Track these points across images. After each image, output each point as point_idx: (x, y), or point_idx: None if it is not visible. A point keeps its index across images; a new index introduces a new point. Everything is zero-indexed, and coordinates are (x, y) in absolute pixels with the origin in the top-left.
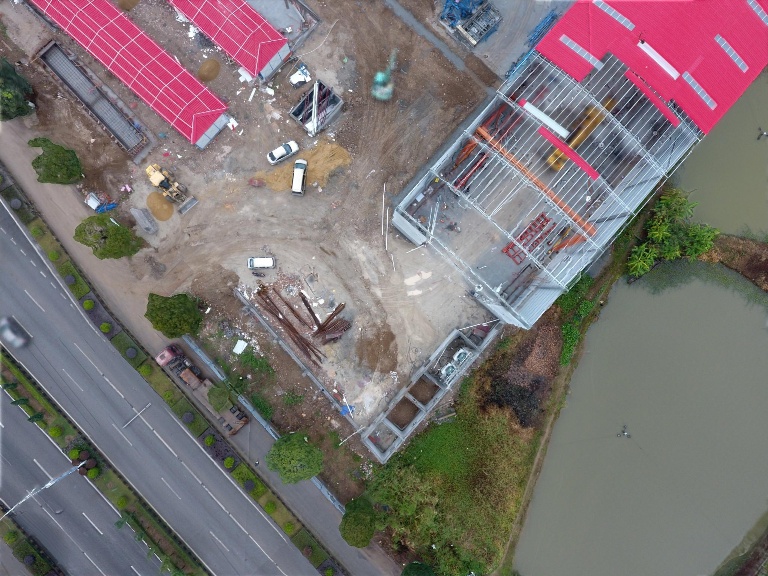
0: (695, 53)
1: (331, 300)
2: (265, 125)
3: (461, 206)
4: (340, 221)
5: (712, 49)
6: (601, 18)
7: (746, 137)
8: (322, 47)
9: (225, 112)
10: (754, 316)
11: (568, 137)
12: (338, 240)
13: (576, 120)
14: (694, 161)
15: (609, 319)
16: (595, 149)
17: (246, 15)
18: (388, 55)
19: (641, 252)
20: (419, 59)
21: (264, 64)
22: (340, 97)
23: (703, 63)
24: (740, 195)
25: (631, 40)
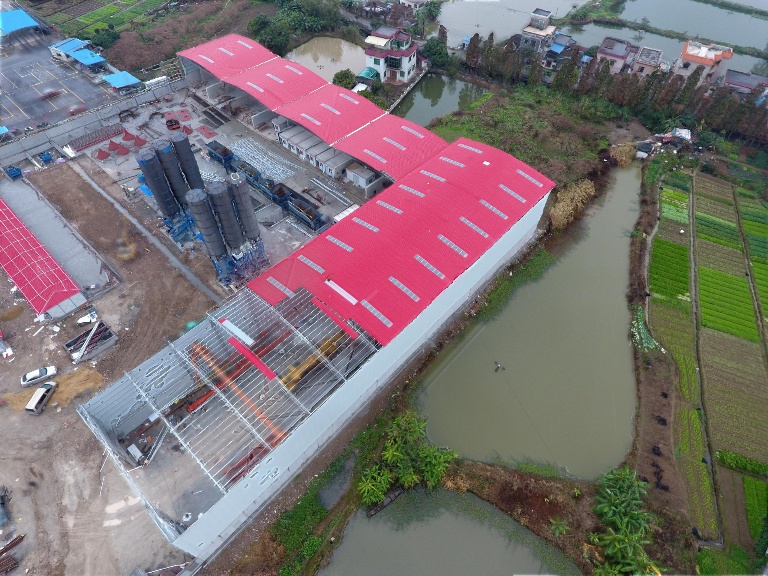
0: (371, 288)
1: (11, 531)
2: (37, 354)
3: (193, 426)
4: (64, 440)
5: (386, 285)
6: (301, 267)
7: (485, 370)
8: (116, 299)
9: (7, 344)
10: (519, 561)
11: (252, 345)
12: (53, 460)
13: (263, 332)
14: (437, 390)
15: (343, 564)
16: (275, 354)
17: (55, 274)
18: (169, 304)
19: (370, 474)
20: (194, 307)
21: (52, 306)
22: (115, 334)
23: (379, 294)
24: (485, 421)
25: (320, 279)
